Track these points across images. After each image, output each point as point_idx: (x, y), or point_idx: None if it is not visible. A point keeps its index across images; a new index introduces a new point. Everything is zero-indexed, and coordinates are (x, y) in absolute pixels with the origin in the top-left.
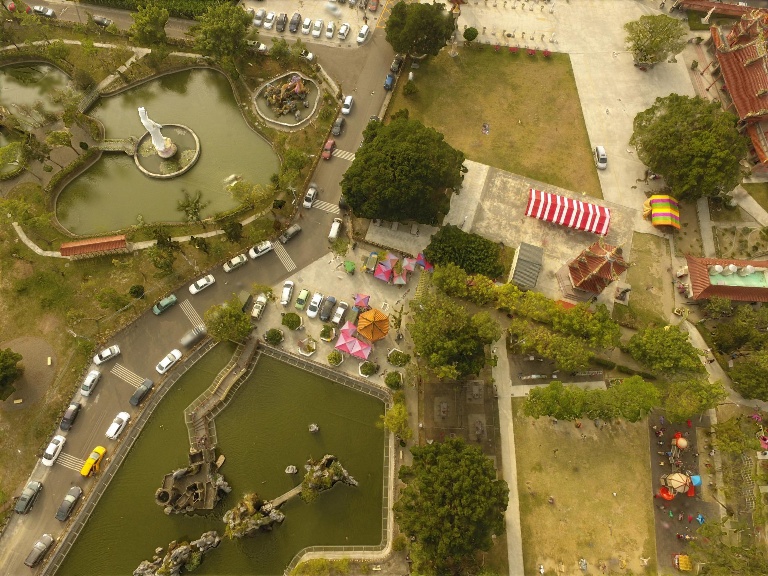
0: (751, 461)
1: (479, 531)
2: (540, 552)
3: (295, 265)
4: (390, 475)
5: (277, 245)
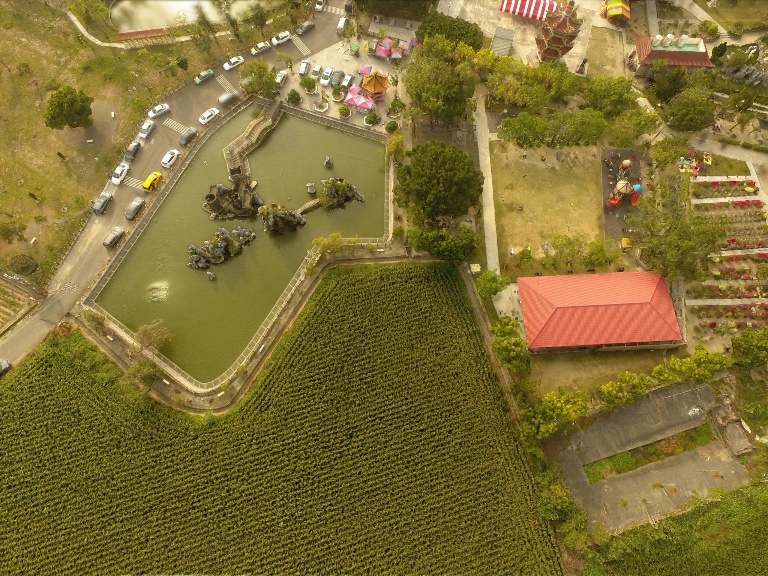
0: (683, 177)
1: (460, 194)
2: (511, 242)
3: (310, 51)
4: (390, 192)
5: (294, 37)
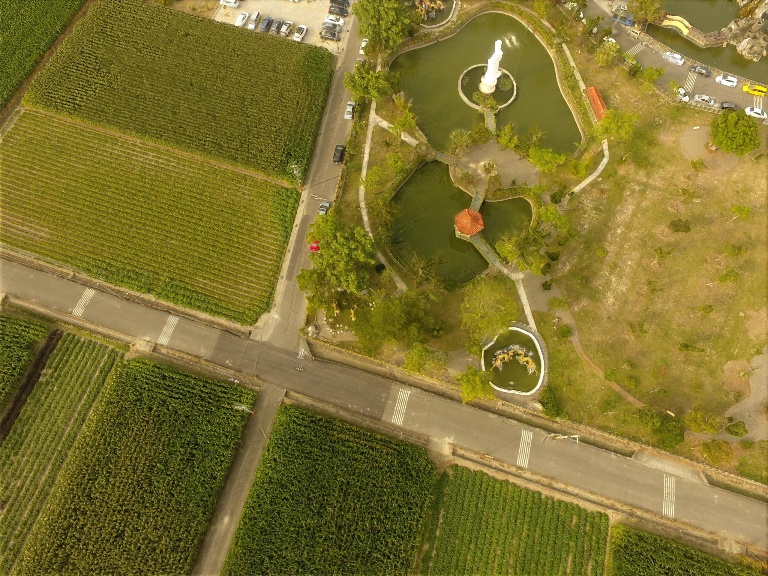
0: None
1: None
2: None
3: None
4: None
5: None
